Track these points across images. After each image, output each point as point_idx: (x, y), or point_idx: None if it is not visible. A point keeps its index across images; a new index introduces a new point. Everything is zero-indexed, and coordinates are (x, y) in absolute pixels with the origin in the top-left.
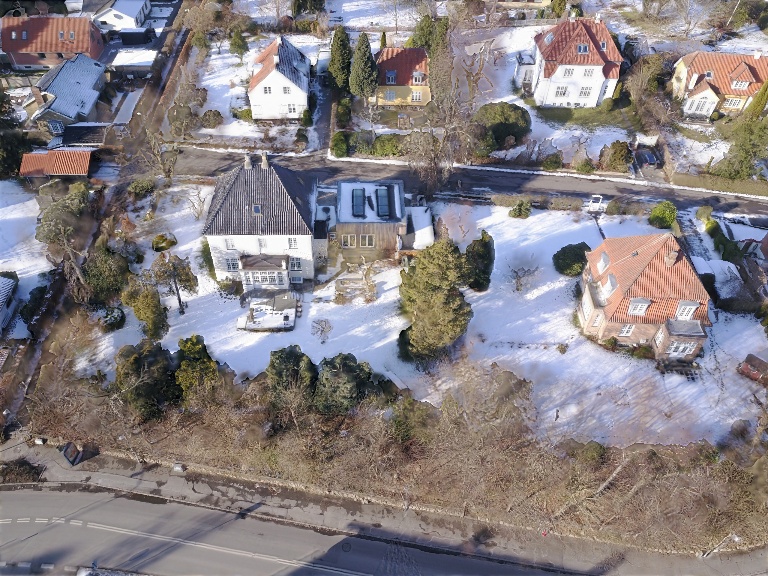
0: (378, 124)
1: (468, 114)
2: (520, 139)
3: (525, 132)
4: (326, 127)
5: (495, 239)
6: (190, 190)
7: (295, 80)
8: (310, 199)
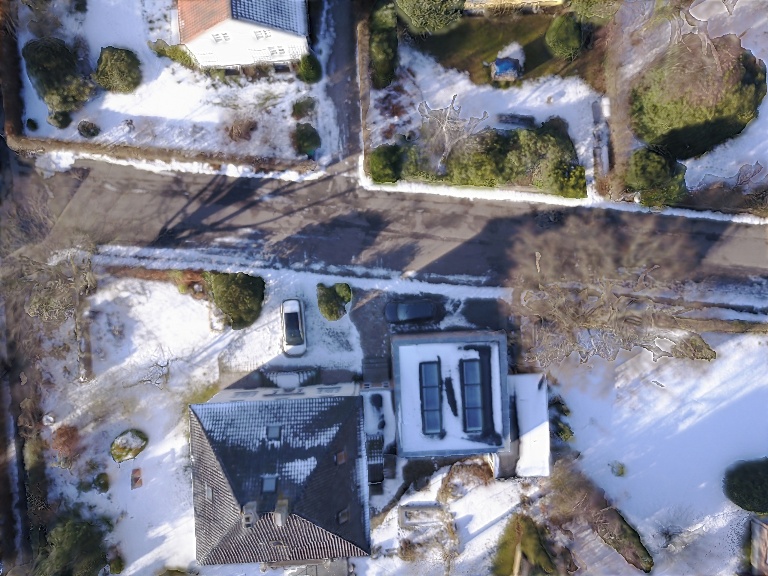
0: (452, 69)
1: (637, 36)
2: (729, 135)
3: (744, 124)
4: (349, 82)
5: (641, 416)
6: (133, 298)
7: (277, 7)
8: (358, 476)
